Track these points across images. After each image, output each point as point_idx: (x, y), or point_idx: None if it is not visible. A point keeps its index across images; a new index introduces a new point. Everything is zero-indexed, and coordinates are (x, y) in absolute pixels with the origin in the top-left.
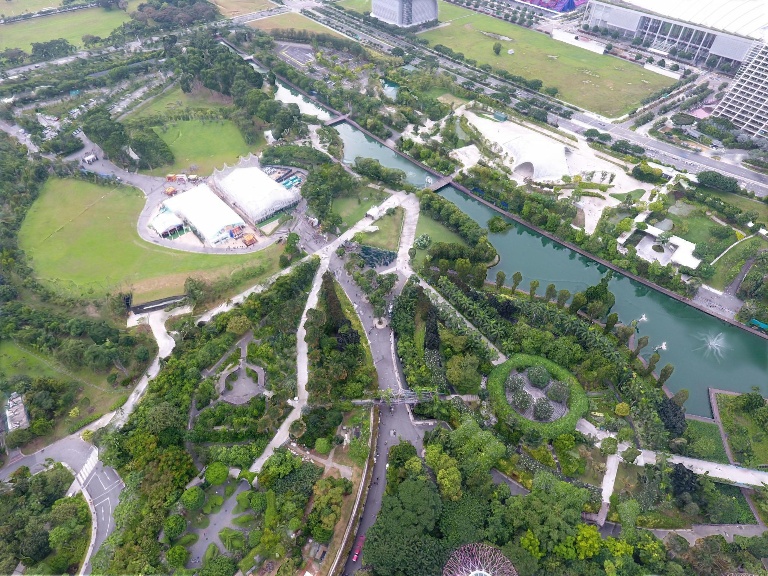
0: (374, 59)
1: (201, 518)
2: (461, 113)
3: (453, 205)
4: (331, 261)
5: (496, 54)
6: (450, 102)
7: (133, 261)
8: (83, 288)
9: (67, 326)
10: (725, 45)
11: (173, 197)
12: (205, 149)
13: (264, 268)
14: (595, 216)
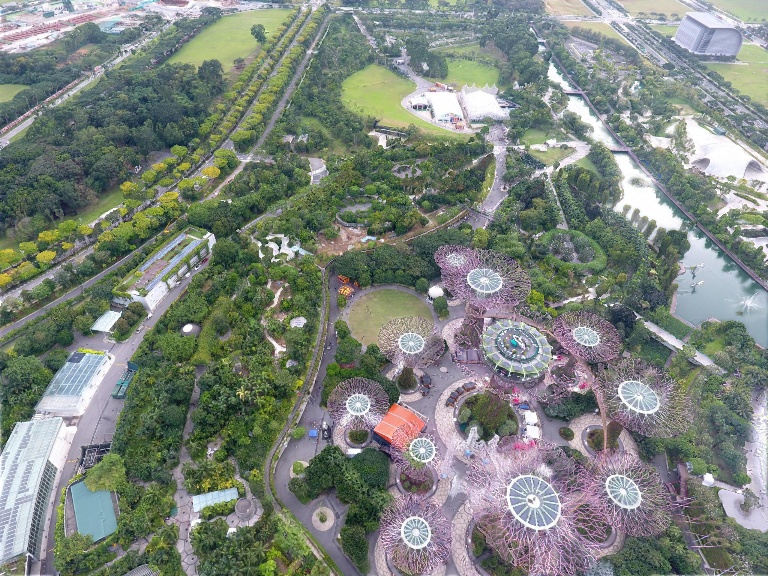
0: (642, 65)
1: None
2: (685, 119)
3: (612, 155)
4: (500, 153)
5: None
6: None
7: (390, 111)
8: (359, 108)
9: (343, 119)
10: None
11: (432, 92)
12: (469, 78)
13: (457, 140)
14: None
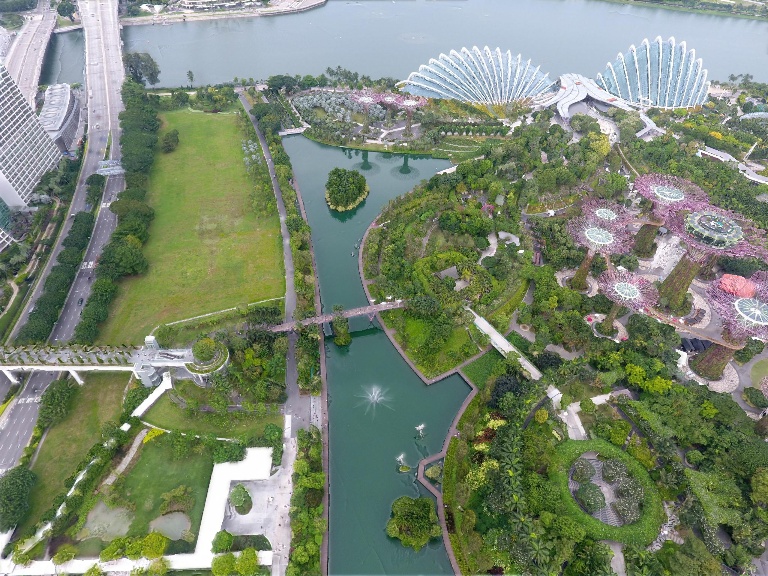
0: None
1: None
2: None
3: None
4: None
5: None
6: None
7: None
8: None
9: None
10: None
11: None
12: None
13: None
14: None
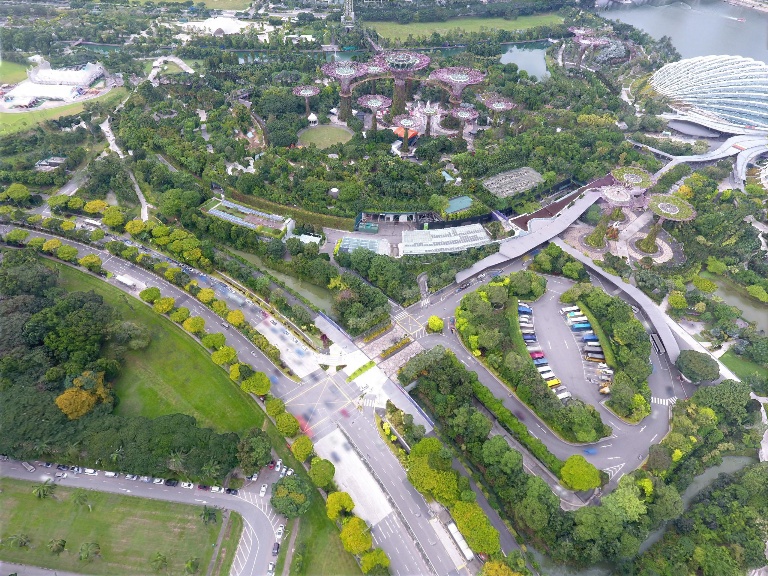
0: (62, 12)
1: None
2: None
3: None
4: None
5: None
6: (146, 19)
7: None
8: (17, 124)
9: (31, 136)
10: None
11: (9, 92)
12: None
13: None
14: None
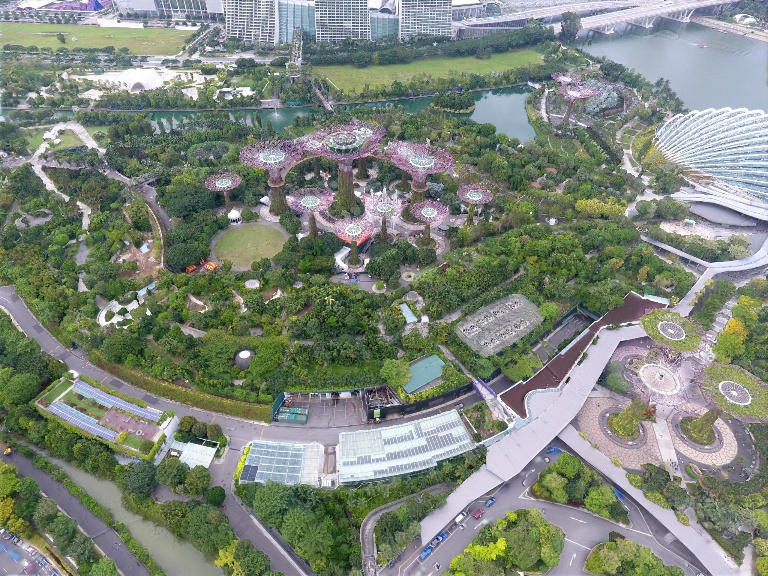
0: None
1: (70, 255)
2: (66, 77)
3: None
4: None
5: (63, 43)
6: (51, 72)
7: None
8: None
9: None
10: (213, 5)
11: None
12: None
13: None
14: (195, 95)
